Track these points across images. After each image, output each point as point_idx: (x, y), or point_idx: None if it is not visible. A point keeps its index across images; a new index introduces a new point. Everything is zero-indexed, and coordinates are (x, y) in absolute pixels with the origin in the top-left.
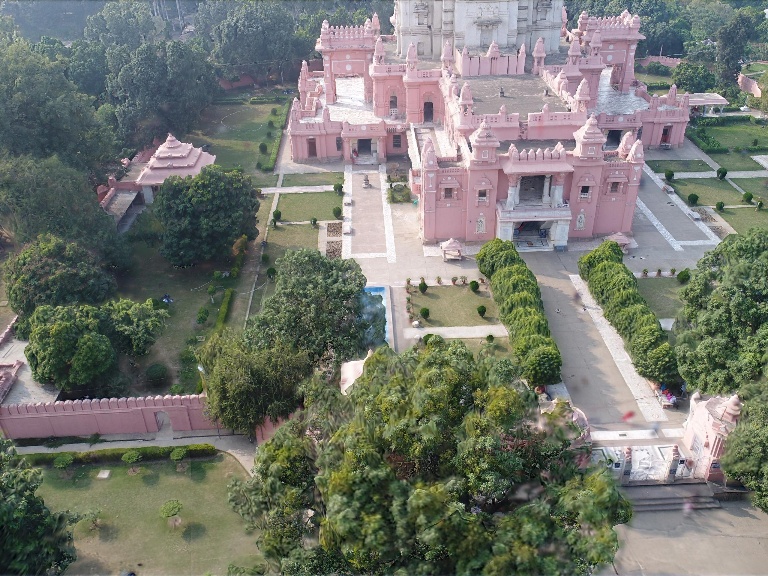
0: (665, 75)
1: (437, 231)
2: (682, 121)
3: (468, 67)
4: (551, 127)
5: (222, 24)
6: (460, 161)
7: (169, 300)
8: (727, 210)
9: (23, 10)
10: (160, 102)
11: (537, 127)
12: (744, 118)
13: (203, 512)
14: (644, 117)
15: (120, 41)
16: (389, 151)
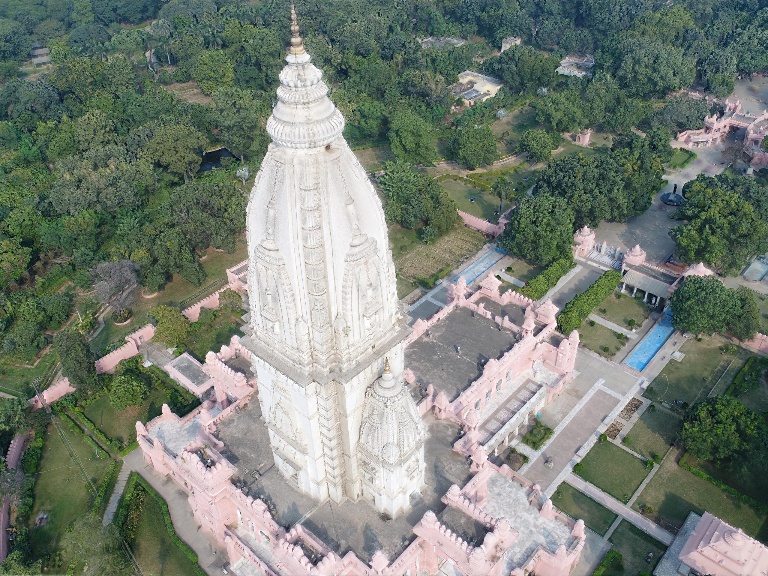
0: None
1: None
2: None
3: None
4: None
5: None
6: None
7: None
8: None
9: None
10: None
11: None
12: None
13: (762, 319)
14: None
15: None
16: None
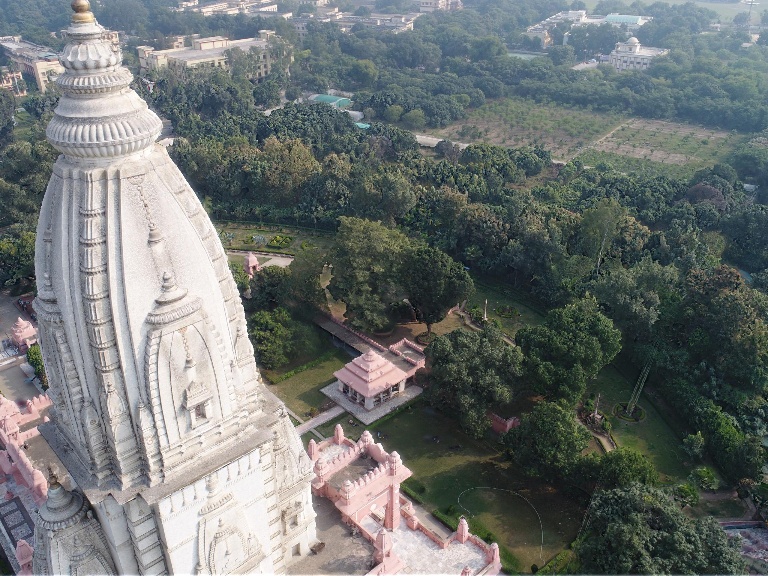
0: None
1: None
2: None
3: None
4: None
5: None
6: None
7: None
8: None
9: None
10: None
11: None
12: None
13: None
14: None
15: None
16: None
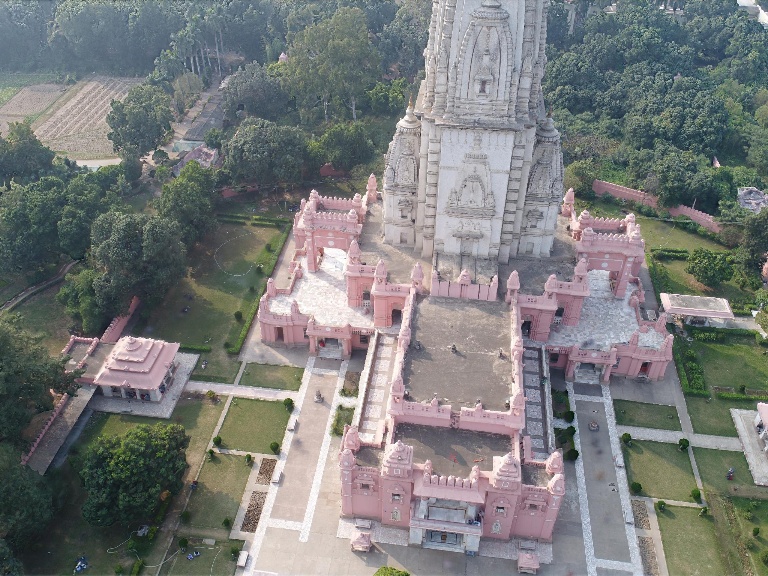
0: (693, 233)
1: (355, 509)
2: (663, 360)
3: (437, 288)
4: (483, 423)
5: (230, 143)
6: (383, 450)
7: (82, 567)
8: (668, 509)
9: (71, 43)
10: (134, 280)
11: (468, 422)
12: (749, 334)
13: None
14: (622, 351)
15: (137, 135)
16: (356, 345)
